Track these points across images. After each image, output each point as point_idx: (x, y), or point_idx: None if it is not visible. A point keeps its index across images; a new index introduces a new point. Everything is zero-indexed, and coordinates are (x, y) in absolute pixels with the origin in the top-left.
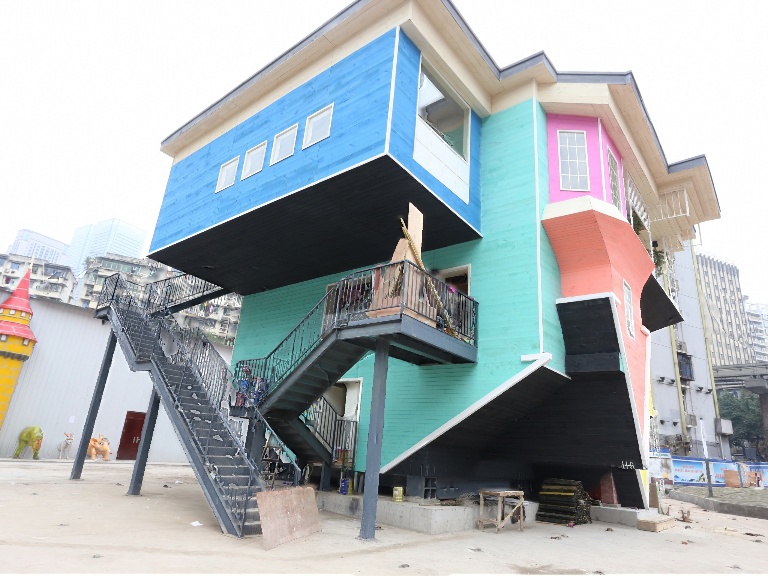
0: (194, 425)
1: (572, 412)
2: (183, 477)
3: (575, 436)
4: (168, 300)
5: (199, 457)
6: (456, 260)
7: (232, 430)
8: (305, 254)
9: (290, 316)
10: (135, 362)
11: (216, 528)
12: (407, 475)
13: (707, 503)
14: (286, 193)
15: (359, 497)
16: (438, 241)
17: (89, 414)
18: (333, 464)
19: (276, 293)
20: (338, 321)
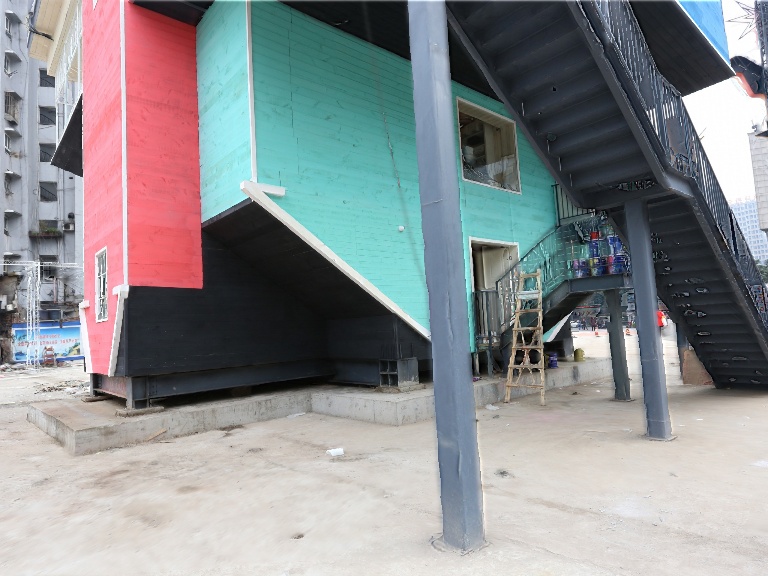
0: None
1: None
2: (98, 480)
3: None
4: None
5: (767, 333)
6: None
7: None
8: None
9: (403, 115)
10: None
11: None
12: (564, 339)
13: None
14: None
15: (572, 365)
16: None
17: None
18: None
19: (359, 47)
20: None
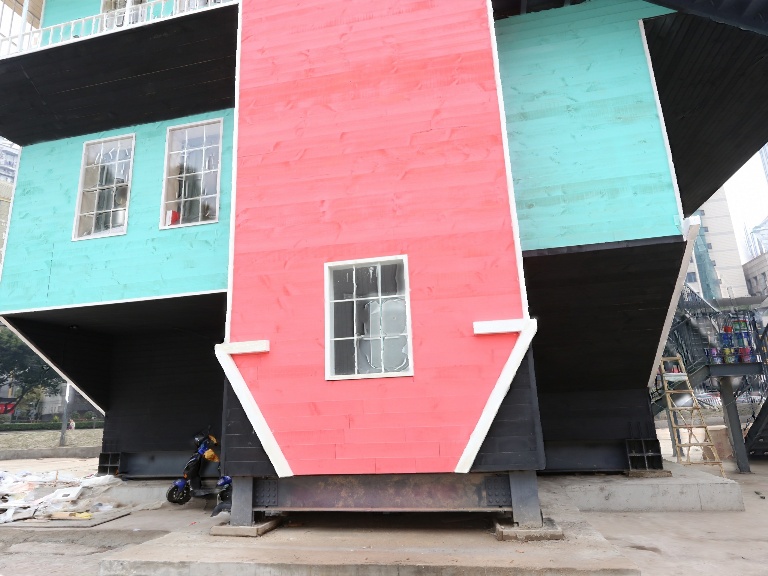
0: None
1: None
2: None
3: None
4: None
5: None
6: None
7: None
8: None
9: None
10: None
11: None
12: None
13: (95, 451)
14: None
15: None
16: None
17: None
18: None
19: None
20: None
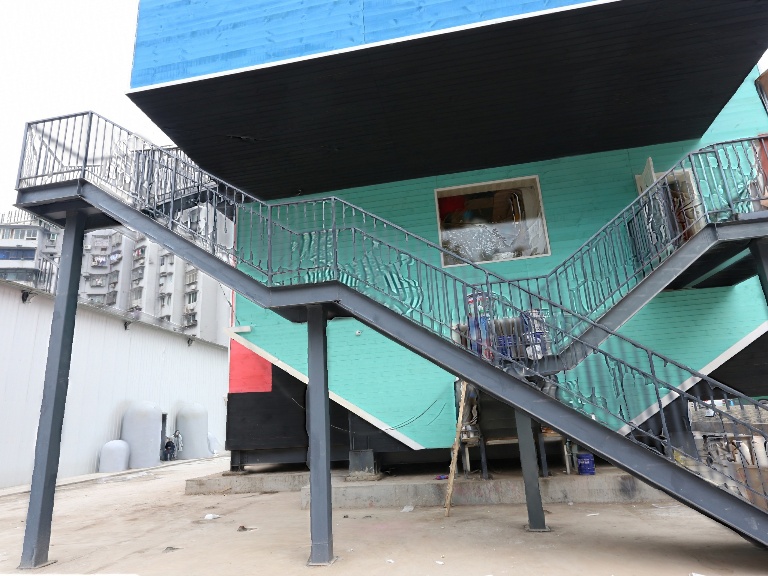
0: (593, 392)
1: (765, 340)
2: (147, 508)
3: (762, 366)
4: (160, 189)
5: None
6: (667, 163)
7: (567, 398)
8: (452, 133)
9: None
10: (260, 289)
11: (750, 575)
12: None
13: None
14: (585, 1)
15: (627, 473)
16: (650, 135)
17: (49, 416)
18: (543, 436)
19: None
20: (710, 213)
